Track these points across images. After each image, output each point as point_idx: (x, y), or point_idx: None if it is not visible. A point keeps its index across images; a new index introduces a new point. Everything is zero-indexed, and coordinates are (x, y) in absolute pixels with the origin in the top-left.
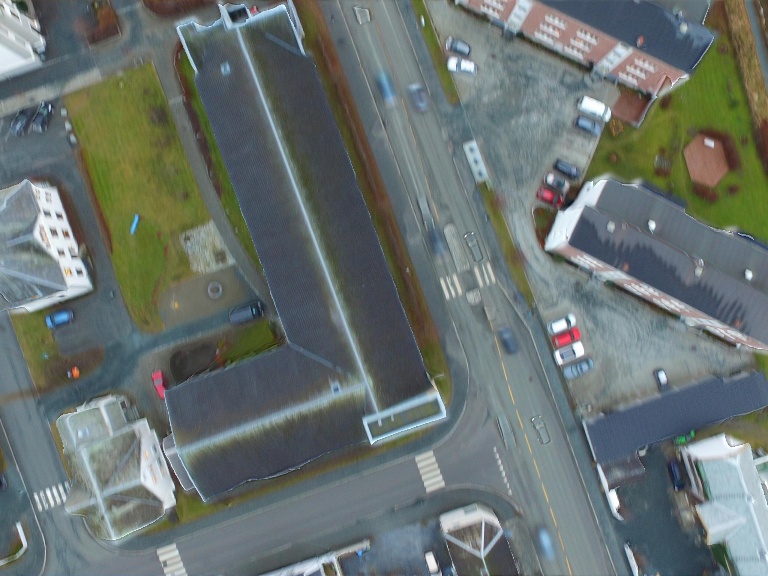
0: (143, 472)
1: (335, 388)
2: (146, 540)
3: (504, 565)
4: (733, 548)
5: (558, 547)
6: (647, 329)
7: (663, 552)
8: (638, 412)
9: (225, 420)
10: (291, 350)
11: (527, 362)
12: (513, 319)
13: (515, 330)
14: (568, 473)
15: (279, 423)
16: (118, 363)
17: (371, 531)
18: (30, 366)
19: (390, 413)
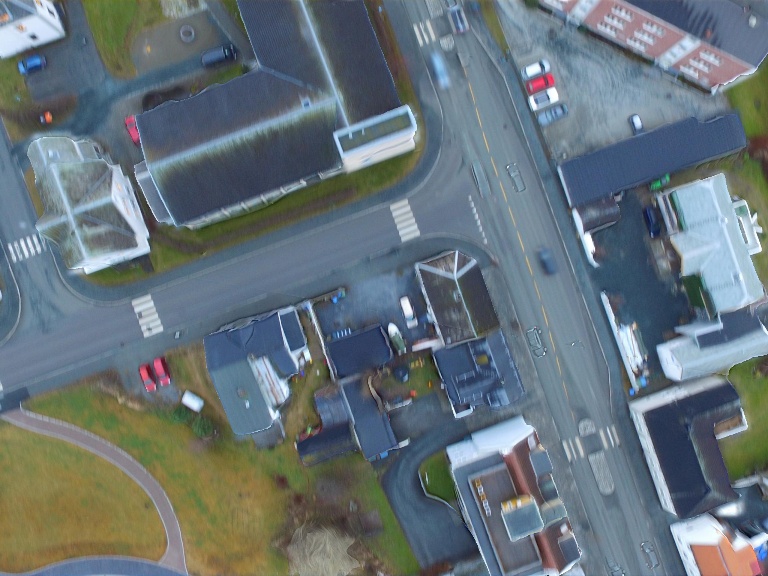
0: (114, 195)
1: (305, 103)
2: (121, 290)
3: (478, 291)
4: (708, 277)
5: (534, 296)
6: (622, 76)
7: (639, 301)
8: (612, 152)
9: (195, 136)
10: (262, 73)
11: (501, 109)
12: (487, 66)
13: (489, 77)
14: (543, 221)
15: (250, 139)
16: (91, 110)
17: (346, 280)
18: (3, 115)
19: (361, 127)
